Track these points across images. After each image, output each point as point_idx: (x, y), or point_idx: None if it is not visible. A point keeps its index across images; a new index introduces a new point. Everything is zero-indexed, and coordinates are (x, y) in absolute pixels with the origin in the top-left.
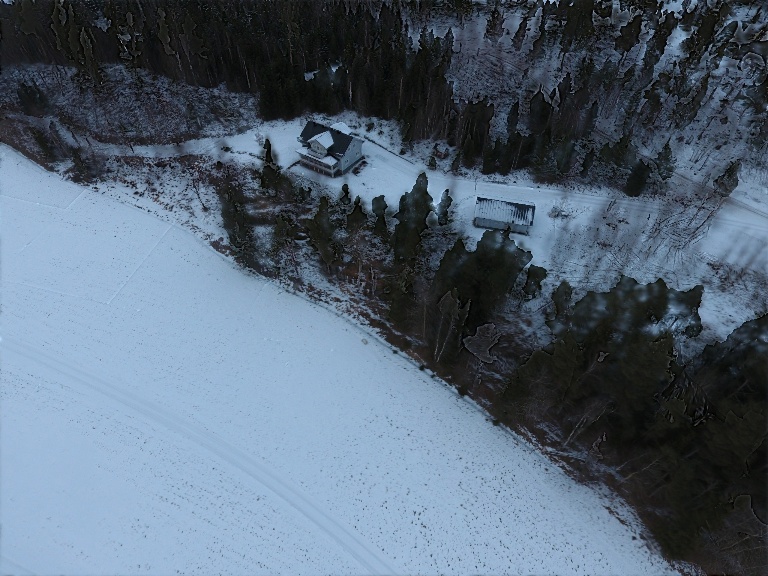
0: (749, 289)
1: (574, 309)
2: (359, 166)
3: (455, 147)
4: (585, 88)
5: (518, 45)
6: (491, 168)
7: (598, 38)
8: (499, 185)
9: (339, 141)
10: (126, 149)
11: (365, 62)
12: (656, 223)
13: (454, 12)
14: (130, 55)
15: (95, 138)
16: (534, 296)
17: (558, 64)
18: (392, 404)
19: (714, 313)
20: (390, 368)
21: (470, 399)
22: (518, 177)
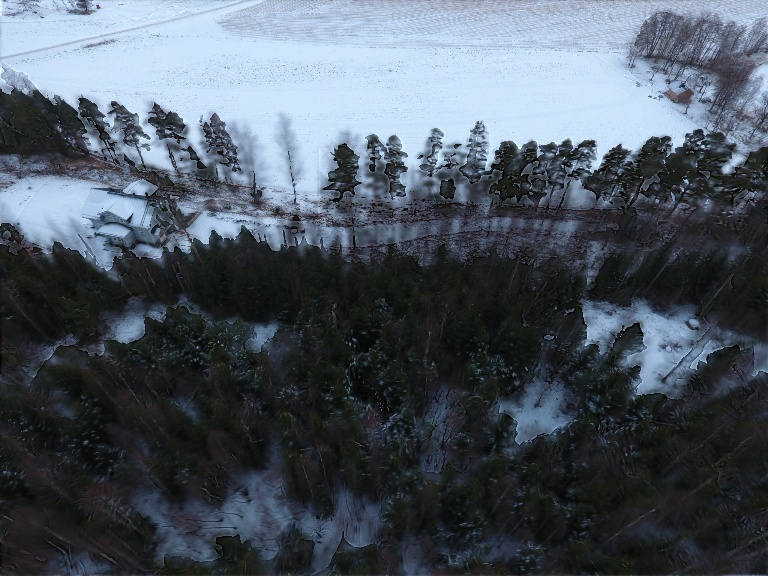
0: None
1: None
2: None
3: None
4: None
5: None
6: None
7: None
8: None
9: None
10: (438, 228)
11: None
12: None
13: None
14: None
15: None
16: None
17: None
18: None
19: None
20: (101, 145)
21: None
22: None
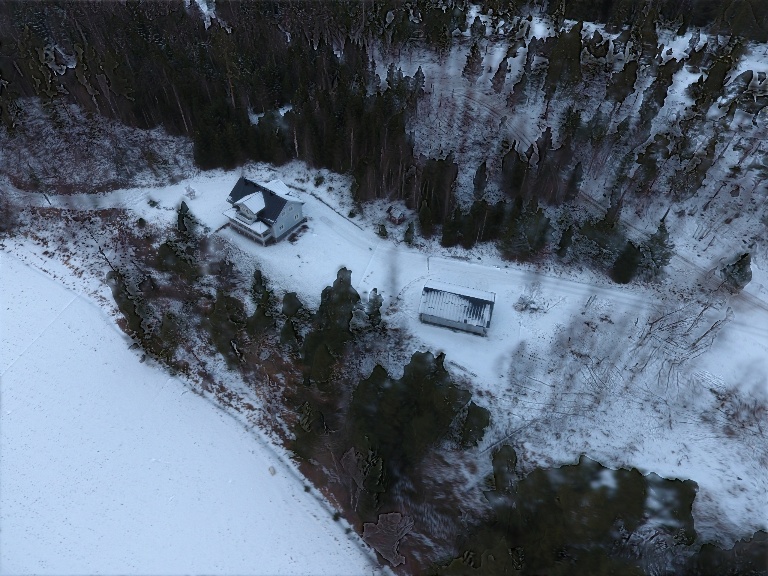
0: (765, 434)
1: (517, 489)
2: (298, 232)
3: (414, 210)
4: (567, 147)
5: (498, 87)
6: (451, 240)
7: (586, 85)
8: (459, 262)
9: (271, 204)
10: None
11: (316, 106)
12: (647, 324)
13: (430, 46)
14: (66, 89)
15: (13, 184)
16: (475, 444)
17: (543, 110)
18: (290, 572)
19: (717, 474)
20: (296, 514)
21: (391, 572)
22: (483, 252)
